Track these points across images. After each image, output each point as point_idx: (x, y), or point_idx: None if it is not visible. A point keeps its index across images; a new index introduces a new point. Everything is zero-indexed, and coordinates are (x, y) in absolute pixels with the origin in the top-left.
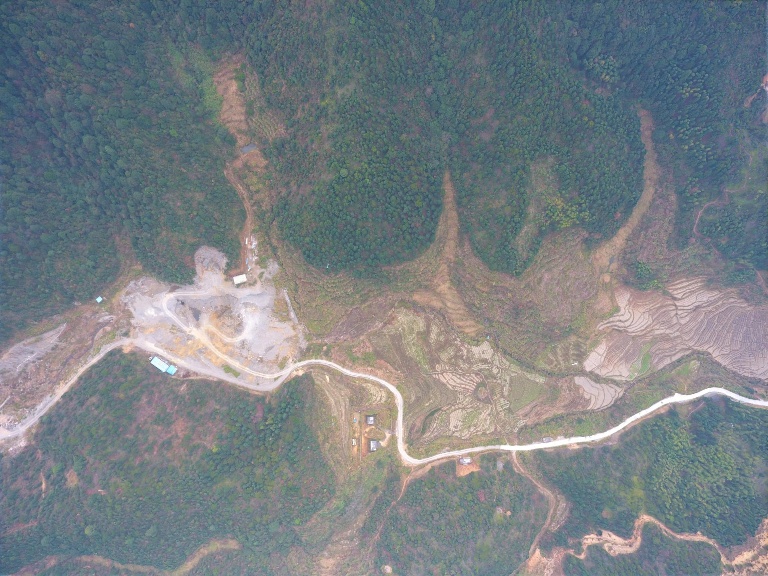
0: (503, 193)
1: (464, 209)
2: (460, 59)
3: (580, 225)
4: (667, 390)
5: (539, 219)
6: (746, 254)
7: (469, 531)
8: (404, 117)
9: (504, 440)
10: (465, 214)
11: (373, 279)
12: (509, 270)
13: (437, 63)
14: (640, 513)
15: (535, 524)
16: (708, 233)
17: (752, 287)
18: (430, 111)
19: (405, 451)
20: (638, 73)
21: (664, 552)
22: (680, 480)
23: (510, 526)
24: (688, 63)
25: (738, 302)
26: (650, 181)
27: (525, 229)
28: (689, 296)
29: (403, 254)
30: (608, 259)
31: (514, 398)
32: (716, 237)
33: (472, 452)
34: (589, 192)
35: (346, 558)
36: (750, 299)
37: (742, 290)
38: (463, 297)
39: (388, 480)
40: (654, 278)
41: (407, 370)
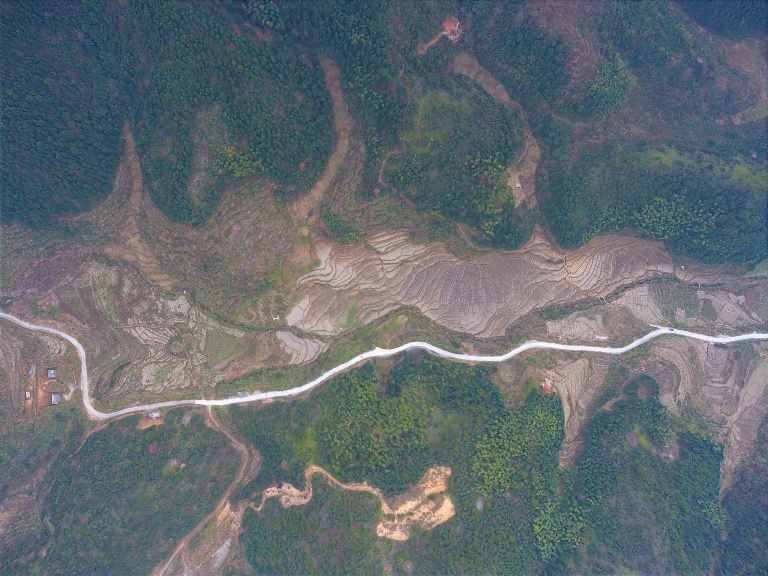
0: (168, 141)
1: (143, 159)
2: (106, 2)
3: (264, 176)
4: (368, 344)
5: (211, 168)
6: (436, 205)
7: (128, 482)
8: (55, 62)
9: (199, 395)
10: (143, 164)
11: (56, 231)
12: (186, 221)
13: (86, 6)
14: (309, 464)
15: (218, 477)
16: (391, 183)
17: (457, 241)
18: (90, 57)
19: (91, 405)
20: (306, 19)
21: (327, 502)
22: (358, 431)
23: (178, 477)
24: (349, 8)
25: (447, 257)
26: (344, 132)
27: (197, 178)
28: (394, 250)
29: (75, 204)
30: (307, 212)
31: (210, 352)
32: (404, 188)
33: (163, 406)
34: (257, 140)
35: (20, 512)
36: (457, 253)
37: (448, 244)
38: (152, 250)
39: (71, 434)
40: (349, 231)
41: (96, 324)
